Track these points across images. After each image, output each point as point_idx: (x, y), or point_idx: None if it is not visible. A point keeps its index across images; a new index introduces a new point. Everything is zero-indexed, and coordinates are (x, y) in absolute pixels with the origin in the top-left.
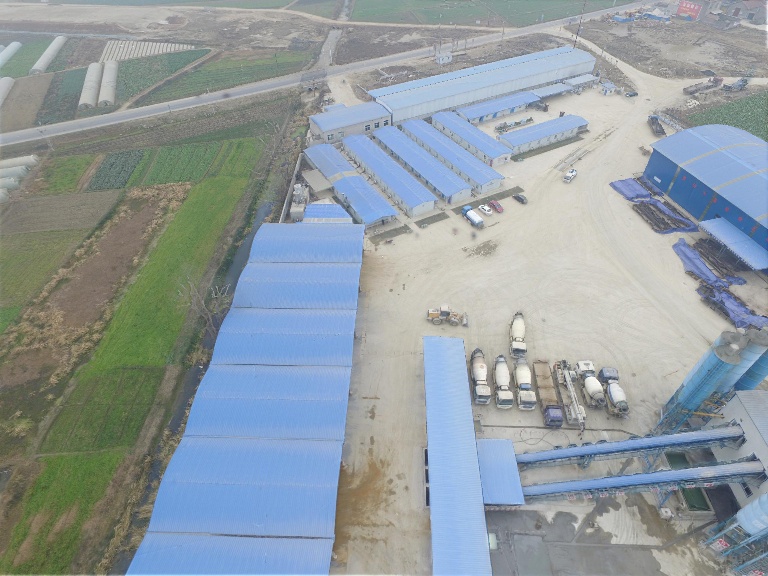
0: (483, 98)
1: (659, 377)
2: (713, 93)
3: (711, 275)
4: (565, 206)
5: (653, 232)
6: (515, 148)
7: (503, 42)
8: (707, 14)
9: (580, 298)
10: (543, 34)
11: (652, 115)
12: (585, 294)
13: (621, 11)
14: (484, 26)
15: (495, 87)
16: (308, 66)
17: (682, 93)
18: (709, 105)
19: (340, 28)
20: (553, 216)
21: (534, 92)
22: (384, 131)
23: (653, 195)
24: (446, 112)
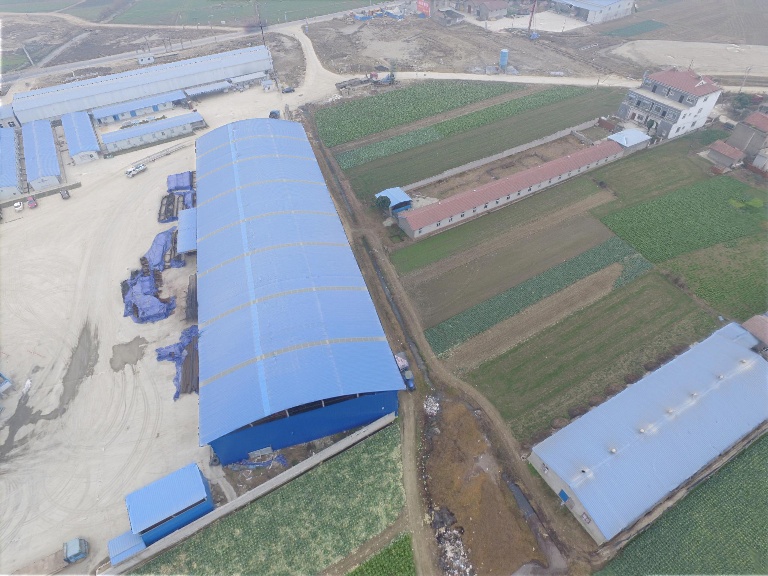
0: (135, 98)
1: (3, 356)
2: (364, 88)
3: (157, 260)
4: (102, 200)
5: (155, 222)
6: (109, 146)
7: (226, 42)
8: (435, 11)
9: (15, 286)
10: (274, 33)
11: (272, 110)
12: (24, 282)
13: None
14: (230, 26)
15: (146, 87)
16: (15, 69)
17: None
18: (350, 99)
19: (92, 30)
20: (79, 210)
21: (189, 91)
22: None
23: None
24: (78, 112)
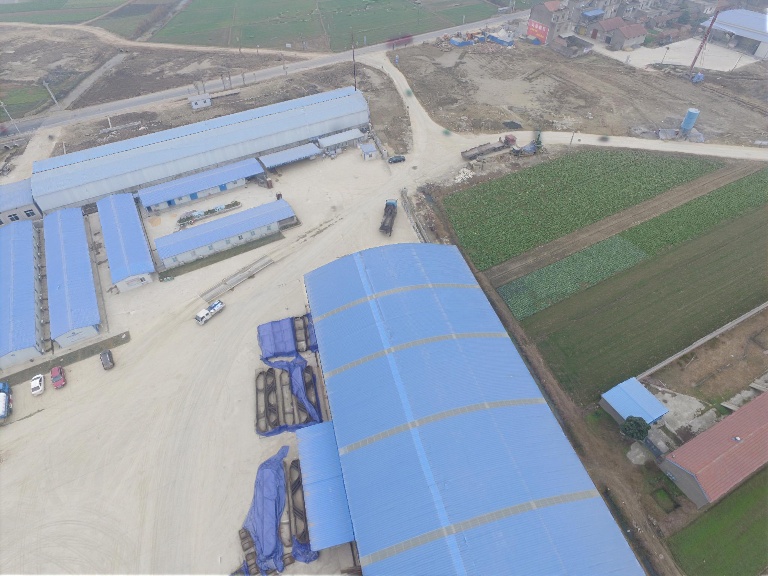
0: (195, 168)
1: None
2: (499, 158)
3: (270, 541)
4: (164, 374)
5: (252, 432)
6: (166, 260)
7: (297, 75)
8: (555, 37)
9: None
10: None
11: (388, 200)
12: None
13: (468, 30)
14: (296, 50)
15: (209, 154)
16: (36, 110)
17: (462, 157)
18: (485, 177)
19: (129, 51)
20: (130, 396)
21: (265, 159)
22: (6, 231)
23: (303, 350)
24: (120, 195)
